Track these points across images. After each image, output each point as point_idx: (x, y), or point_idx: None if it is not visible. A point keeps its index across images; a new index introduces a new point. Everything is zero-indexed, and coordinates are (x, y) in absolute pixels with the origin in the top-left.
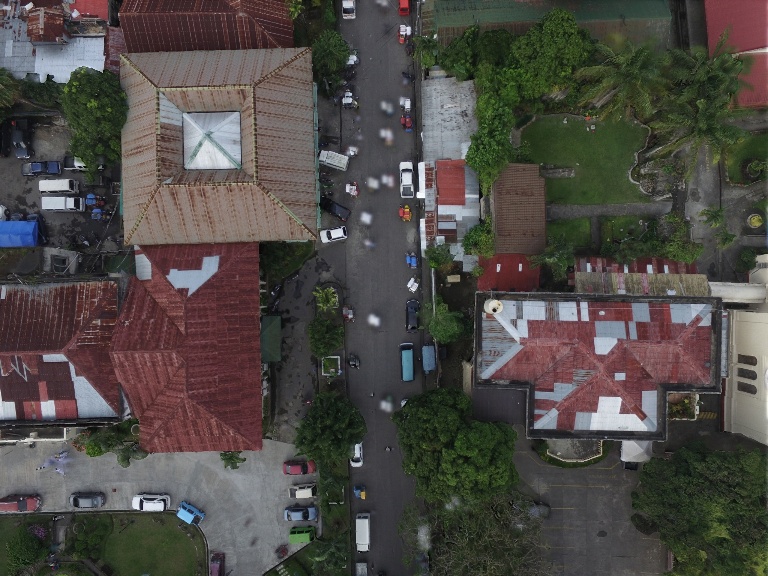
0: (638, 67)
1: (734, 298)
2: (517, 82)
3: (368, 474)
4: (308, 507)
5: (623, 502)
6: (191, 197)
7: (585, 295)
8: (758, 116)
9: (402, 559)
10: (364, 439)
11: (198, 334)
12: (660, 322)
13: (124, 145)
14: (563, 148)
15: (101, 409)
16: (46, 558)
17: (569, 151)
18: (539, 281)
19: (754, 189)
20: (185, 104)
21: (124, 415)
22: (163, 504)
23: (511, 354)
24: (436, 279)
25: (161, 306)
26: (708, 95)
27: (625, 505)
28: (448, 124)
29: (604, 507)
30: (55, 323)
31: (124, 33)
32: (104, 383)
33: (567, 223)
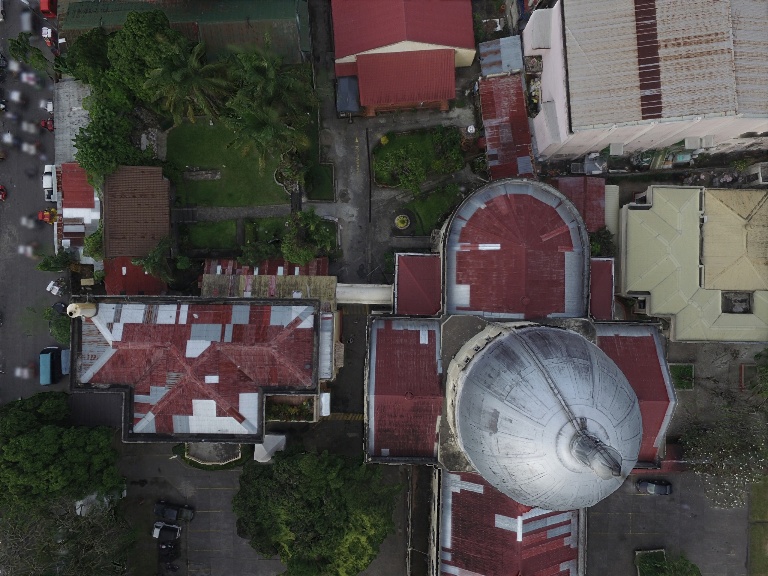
0: (162, 69)
1: (362, 299)
2: (124, 84)
3: None
4: None
5: None
6: None
7: (183, 298)
8: (409, 117)
9: None
10: None
11: None
12: (257, 324)
13: None
14: (210, 150)
15: None
16: None
17: (216, 153)
18: None
19: (405, 190)
20: None
21: None
22: None
23: (106, 358)
24: (72, 282)
25: None
26: None
27: None
28: (76, 127)
29: None
30: None
31: None
32: None
33: (212, 225)
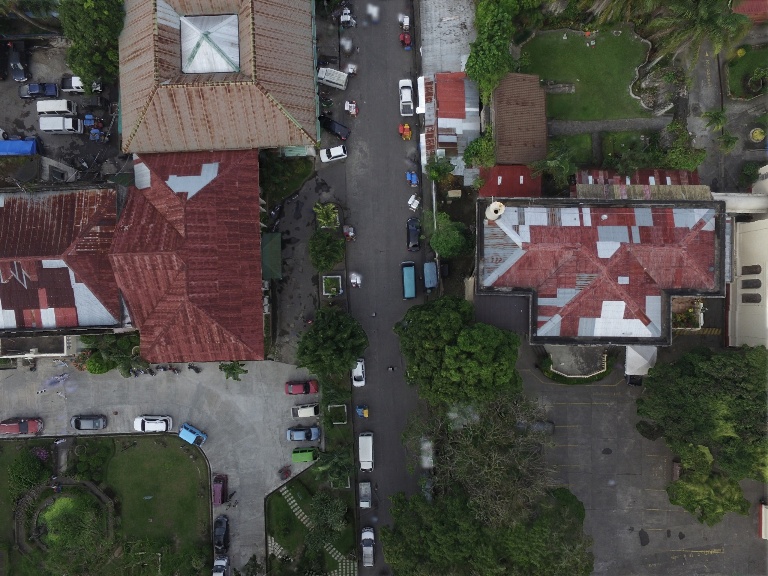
0: None
1: (737, 208)
2: None
3: (371, 394)
4: (311, 427)
5: (628, 419)
6: (189, 99)
7: (587, 200)
8: (759, 31)
9: (406, 466)
10: (366, 359)
11: (198, 238)
12: (663, 226)
13: (121, 52)
14: (563, 64)
15: (101, 317)
16: (48, 480)
17: (569, 67)
18: None
19: (756, 104)
20: (182, 6)
21: (124, 322)
22: (165, 424)
23: (513, 260)
24: (437, 195)
25: (160, 212)
26: None
27: (630, 422)
28: (447, 37)
29: (609, 424)
30: (54, 229)
31: None
32: (104, 290)
33: (568, 139)
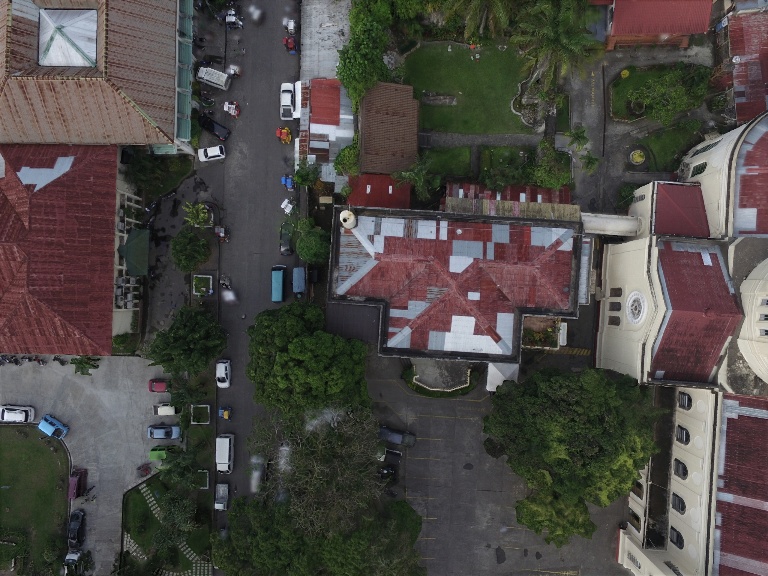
0: None
1: (606, 230)
2: None
3: (236, 396)
4: (172, 426)
5: None
6: (41, 91)
7: (444, 214)
8: (646, 53)
9: None
10: (233, 361)
11: (43, 230)
12: (519, 244)
13: None
14: (446, 76)
15: None
16: None
17: (452, 79)
18: None
19: (639, 126)
20: None
21: None
22: (24, 415)
23: (366, 269)
24: (309, 200)
25: (11, 203)
26: (559, 5)
27: None
28: (325, 43)
29: (472, 439)
30: None
31: None
32: None
33: (446, 151)
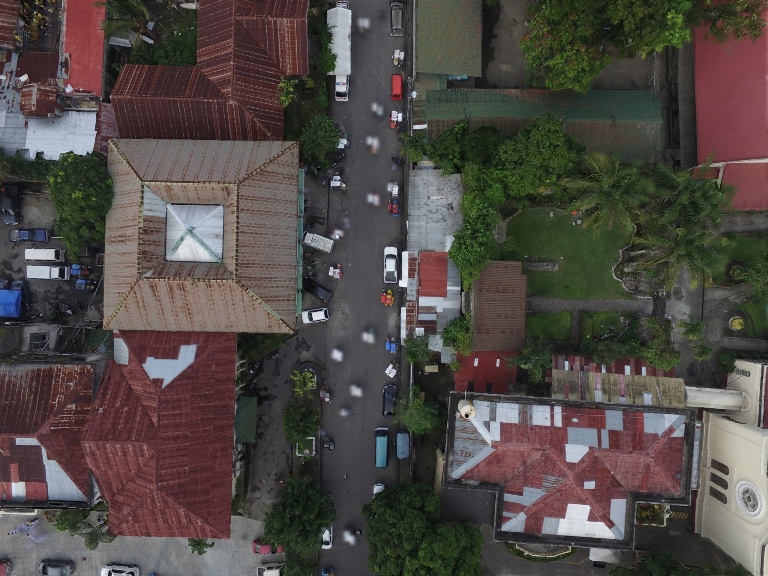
0: (619, 193)
1: (710, 404)
2: (503, 182)
3: (337, 556)
4: None
5: None
6: (170, 290)
7: (559, 400)
8: (745, 218)
9: None
10: (335, 521)
11: (170, 426)
12: (633, 431)
13: (108, 230)
14: (548, 241)
15: (71, 492)
16: None
17: (554, 244)
18: (516, 376)
19: (737, 291)
20: (169, 196)
21: (94, 500)
22: None
23: (482, 456)
24: (414, 368)
25: (136, 393)
26: (689, 219)
27: None
28: (433, 216)
29: None
30: (30, 406)
31: (115, 114)
32: (75, 467)
33: (548, 316)
